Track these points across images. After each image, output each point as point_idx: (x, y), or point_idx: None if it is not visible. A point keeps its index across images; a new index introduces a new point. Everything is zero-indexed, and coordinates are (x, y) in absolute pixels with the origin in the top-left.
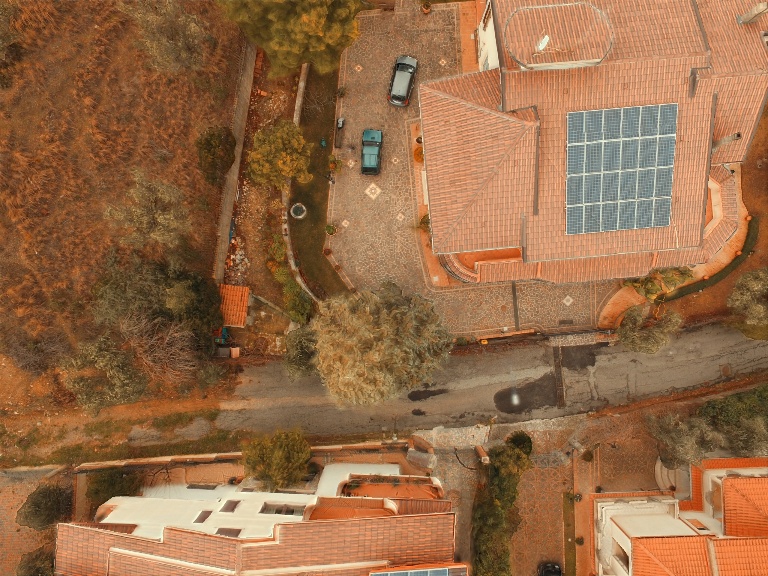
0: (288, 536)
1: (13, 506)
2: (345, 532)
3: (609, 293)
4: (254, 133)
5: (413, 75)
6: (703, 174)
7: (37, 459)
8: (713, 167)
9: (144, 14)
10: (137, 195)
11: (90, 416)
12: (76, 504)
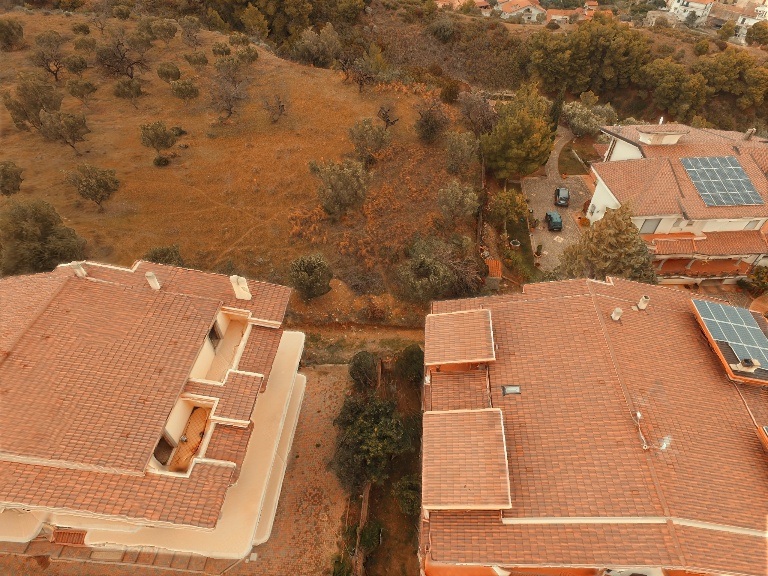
0: (618, 284)
1: (317, 392)
2: (656, 292)
3: (746, 303)
4: (486, 206)
5: None
6: (767, 184)
7: (341, 360)
8: None
9: None
10: None
11: (385, 335)
12: (379, 384)
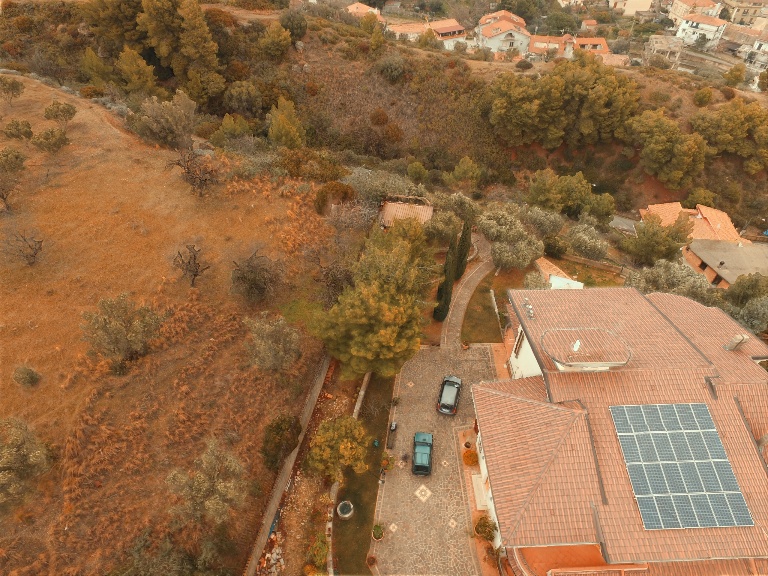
0: None
1: None
2: None
3: None
4: (315, 428)
5: (459, 389)
6: (762, 470)
7: None
8: None
9: None
10: (207, 460)
11: None
12: None
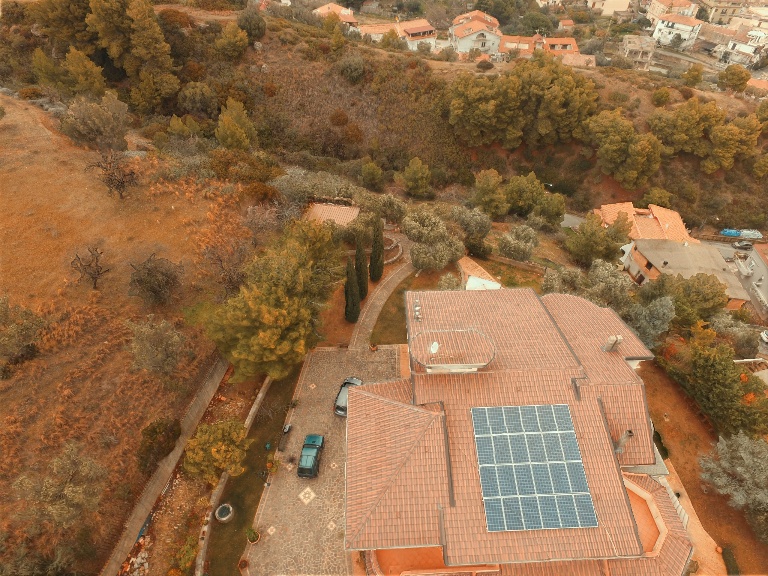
0: None
1: None
2: None
3: None
4: None
5: None
6: (615, 471)
7: None
8: (639, 477)
9: (141, 328)
10: (58, 464)
11: None
12: None
